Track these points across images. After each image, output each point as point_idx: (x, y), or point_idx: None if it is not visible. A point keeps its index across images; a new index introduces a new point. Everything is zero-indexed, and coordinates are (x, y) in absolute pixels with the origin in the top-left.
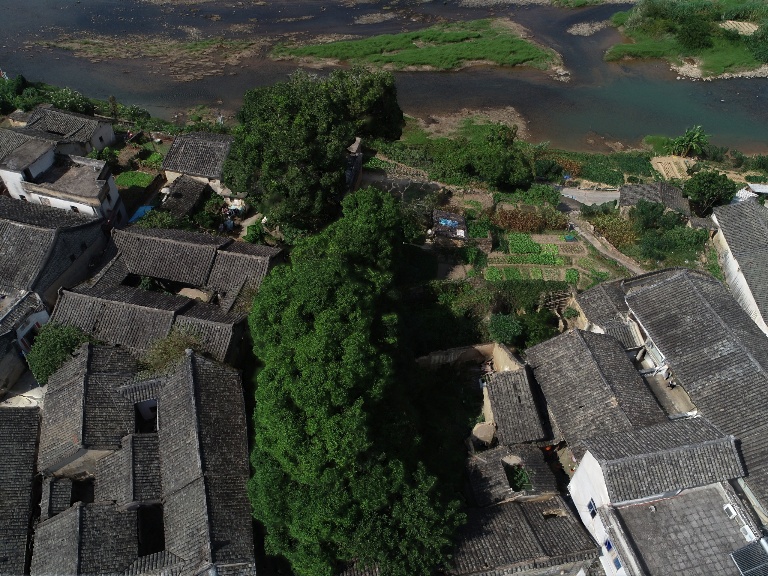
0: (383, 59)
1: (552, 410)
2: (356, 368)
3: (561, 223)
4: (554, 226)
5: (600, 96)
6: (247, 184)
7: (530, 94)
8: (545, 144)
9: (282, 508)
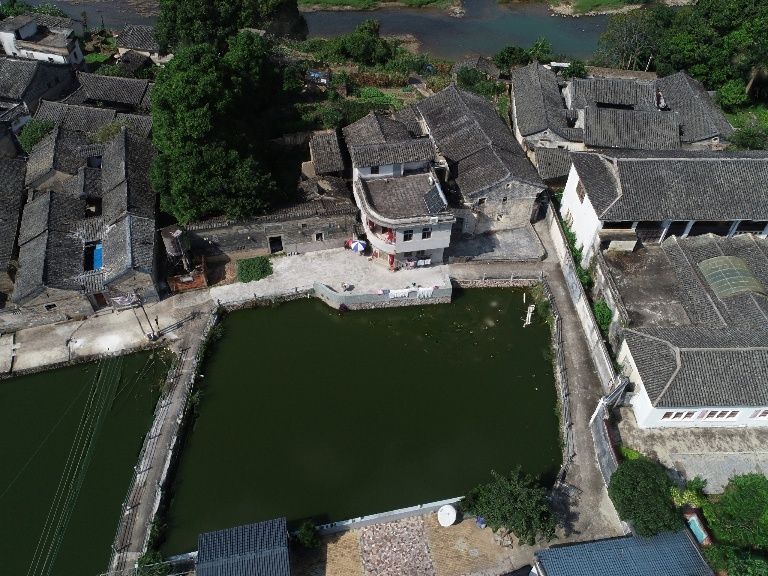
0: (312, 1)
1: (350, 154)
2: (206, 88)
3: (401, 80)
4: (397, 83)
5: (485, 27)
6: (168, 36)
7: (428, 26)
8: (426, 54)
9: (167, 177)
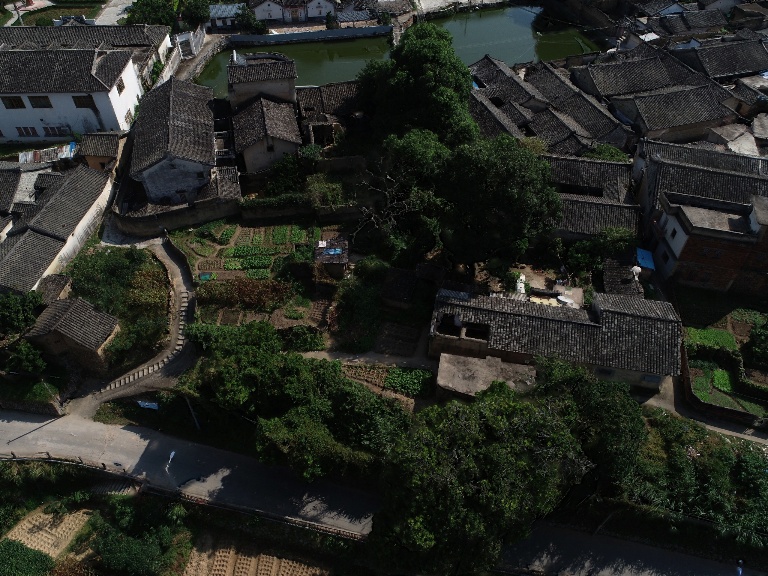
0: None
1: None
2: None
3: None
4: None
5: None
6: None
7: None
8: None
9: None
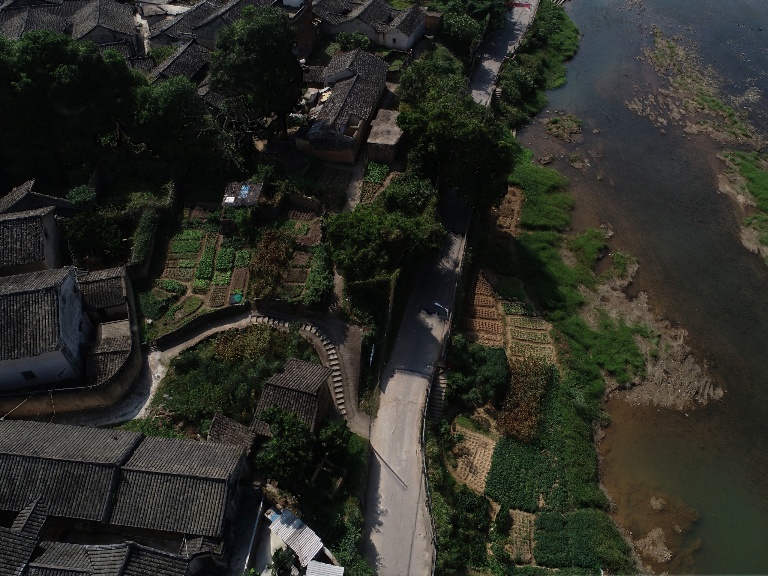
0: None
1: None
2: None
3: None
4: None
5: None
6: None
7: None
8: (576, 399)
9: None
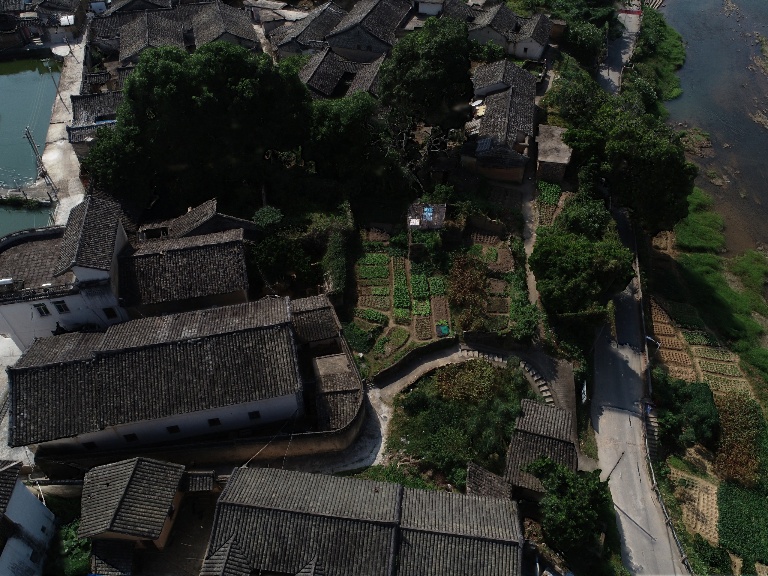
0: None
1: None
2: None
3: None
4: None
5: None
6: None
7: None
8: None
9: None
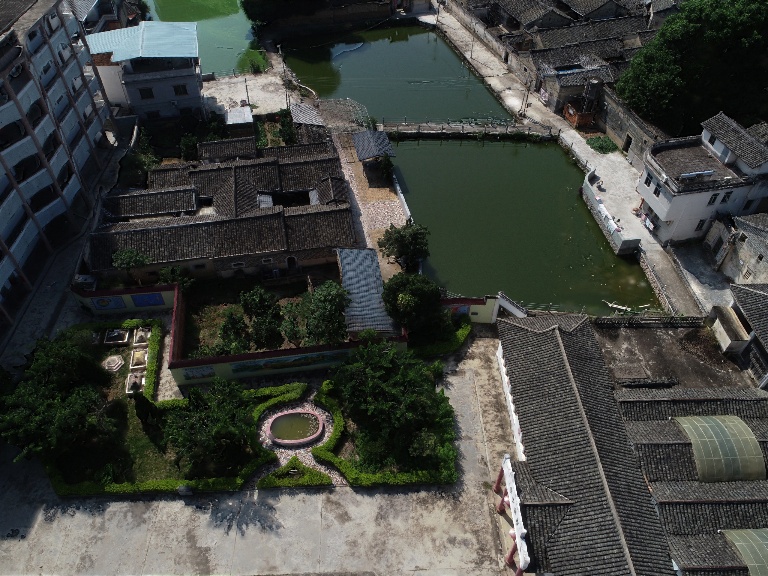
0: None
1: None
2: None
3: None
4: None
5: None
6: None
7: None
8: None
9: None
